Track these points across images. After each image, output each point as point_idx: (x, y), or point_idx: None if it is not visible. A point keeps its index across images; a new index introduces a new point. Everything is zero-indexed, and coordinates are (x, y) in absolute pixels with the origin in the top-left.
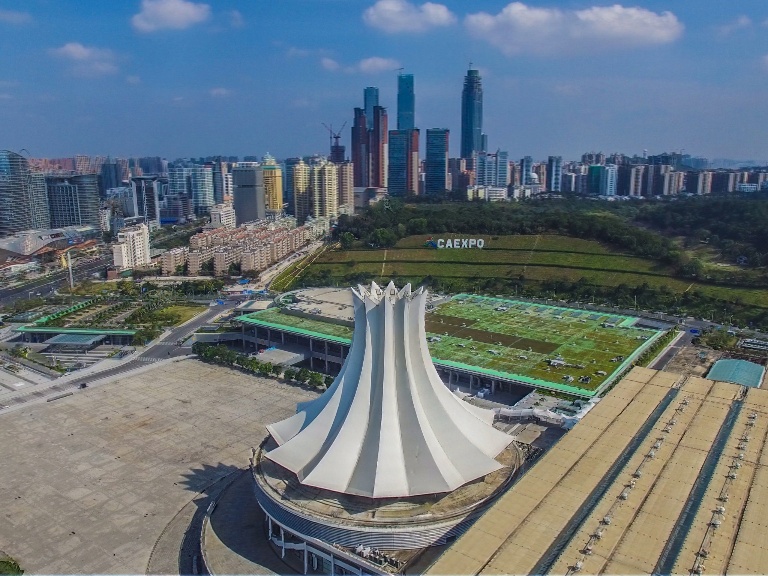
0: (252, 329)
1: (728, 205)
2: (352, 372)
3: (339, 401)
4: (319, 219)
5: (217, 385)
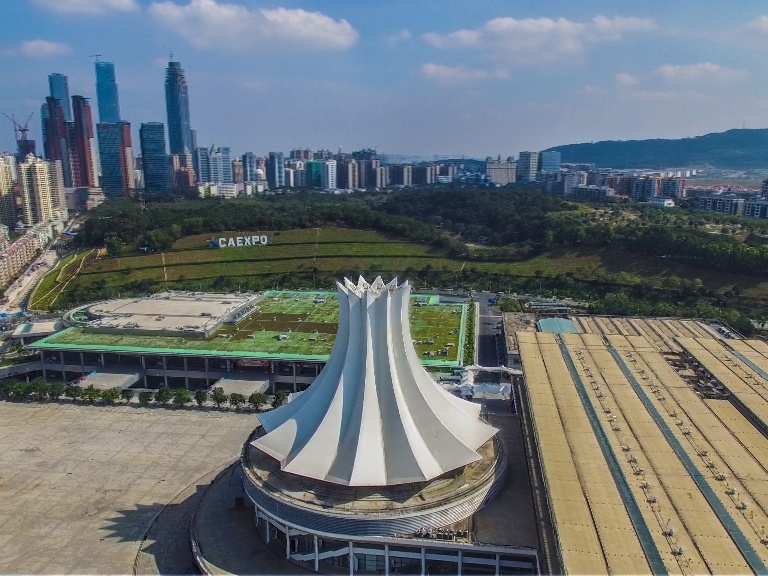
0: (52, 356)
1: (450, 194)
2: (350, 369)
3: (342, 400)
4: (40, 225)
5: (57, 424)
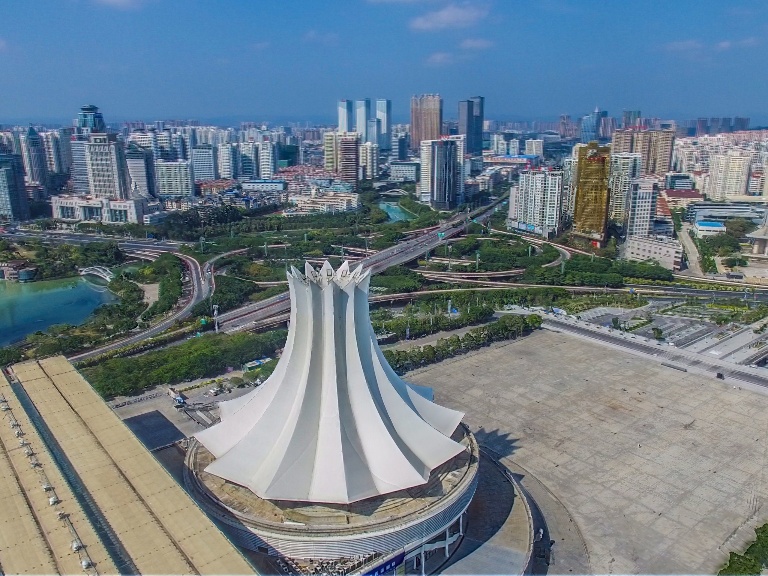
0: None
1: None
2: None
3: None
4: None
5: (759, 445)
